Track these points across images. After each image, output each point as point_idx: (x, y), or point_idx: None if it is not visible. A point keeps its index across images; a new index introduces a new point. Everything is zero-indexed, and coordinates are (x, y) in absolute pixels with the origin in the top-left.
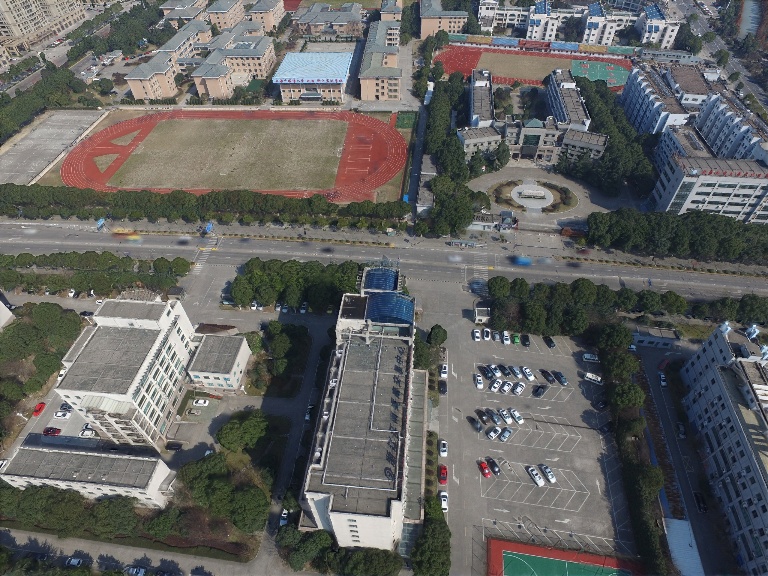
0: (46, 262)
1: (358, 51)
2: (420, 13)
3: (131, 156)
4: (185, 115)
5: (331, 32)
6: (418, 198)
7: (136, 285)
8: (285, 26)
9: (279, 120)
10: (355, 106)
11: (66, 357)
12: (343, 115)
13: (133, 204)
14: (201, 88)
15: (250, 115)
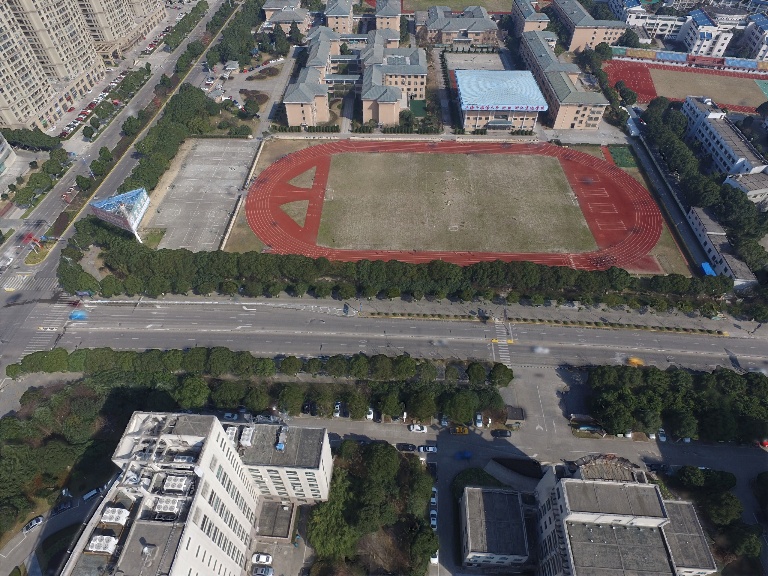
0: (320, 369)
1: (508, 65)
2: (571, 22)
3: (325, 204)
4: (358, 147)
5: (464, 41)
6: (732, 270)
7: (602, 457)
8: (407, 32)
9: (474, 155)
10: (551, 136)
11: (470, 544)
12: (545, 148)
13: (384, 278)
14: (368, 113)
15: (436, 147)
